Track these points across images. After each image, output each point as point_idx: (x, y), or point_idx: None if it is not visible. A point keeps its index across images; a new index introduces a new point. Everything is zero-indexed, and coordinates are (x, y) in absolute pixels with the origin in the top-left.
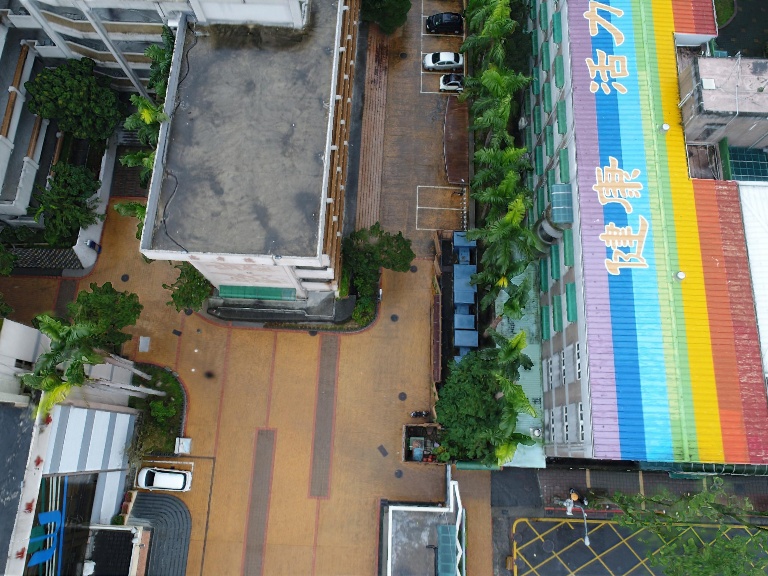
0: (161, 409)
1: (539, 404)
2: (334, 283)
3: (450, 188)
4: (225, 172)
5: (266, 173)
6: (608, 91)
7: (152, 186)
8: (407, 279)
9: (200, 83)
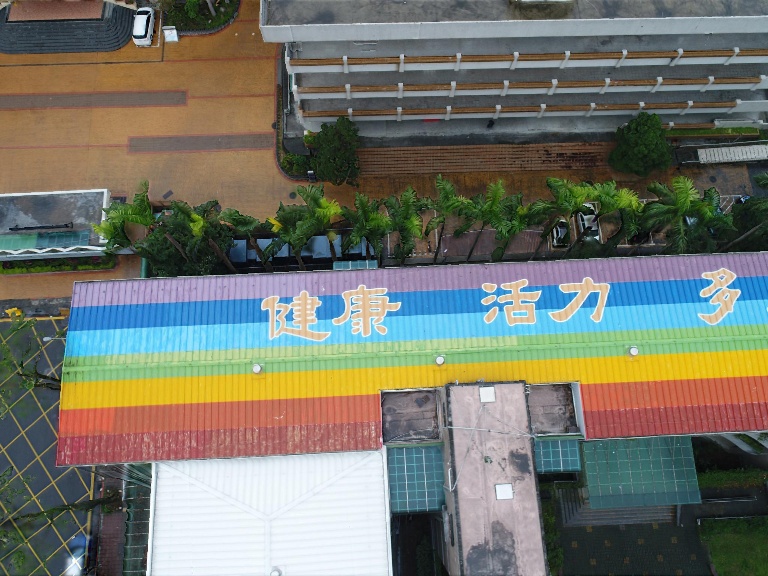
0: (192, 4)
1: None
2: (300, 112)
3: (436, 239)
4: None
5: None
6: (486, 302)
7: None
8: None
9: None
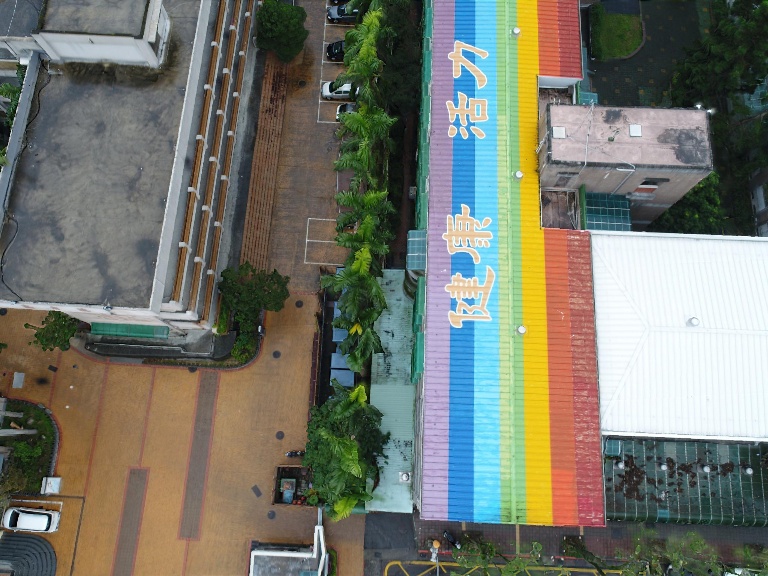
0: (24, 449)
1: (410, 447)
2: (203, 323)
3: None
4: (67, 217)
5: (109, 218)
6: (466, 136)
7: None
8: (292, 314)
9: (50, 124)
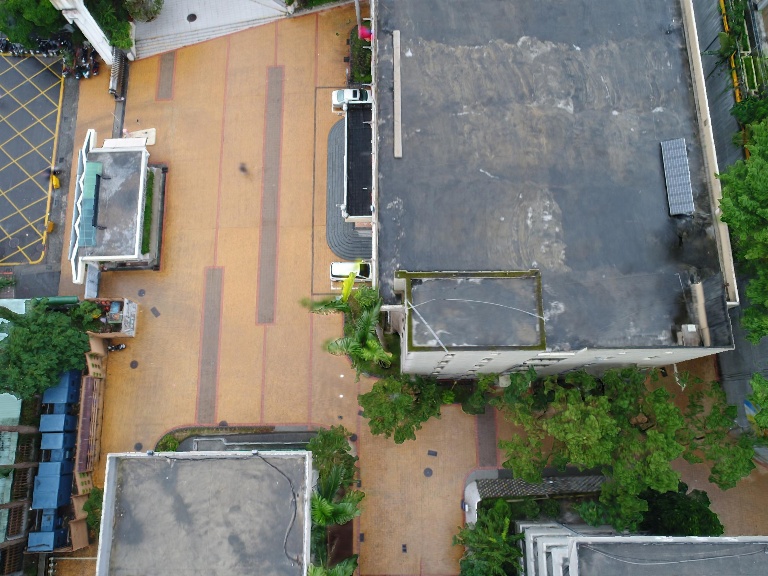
0: None
1: None
2: None
3: None
4: (228, 568)
5: (179, 569)
6: None
7: (305, 538)
8: None
9: None
